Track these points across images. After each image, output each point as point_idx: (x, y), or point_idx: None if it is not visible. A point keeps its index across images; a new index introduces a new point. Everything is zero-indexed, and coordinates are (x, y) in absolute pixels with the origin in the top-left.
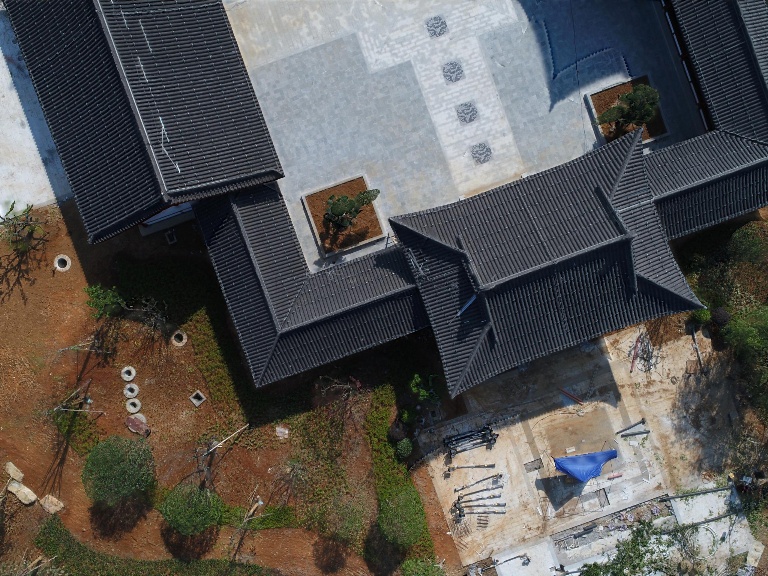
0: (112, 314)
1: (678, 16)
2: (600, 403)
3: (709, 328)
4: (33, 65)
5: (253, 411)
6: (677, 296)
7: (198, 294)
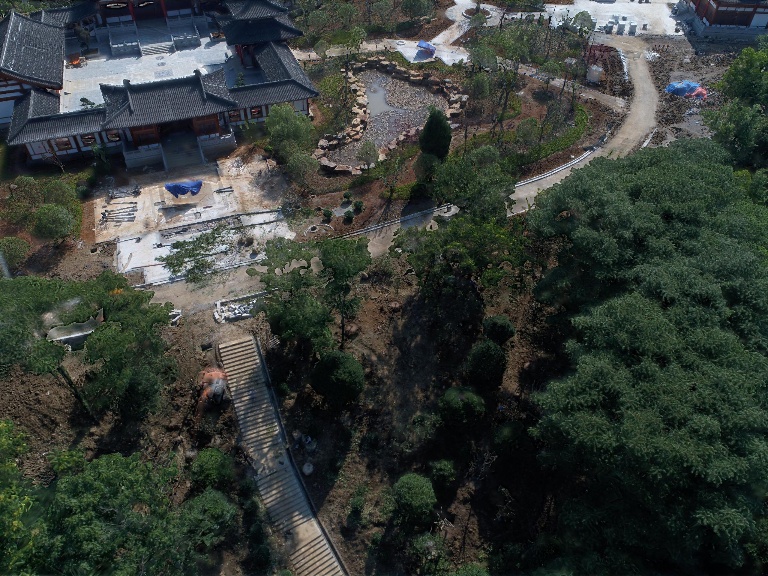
0: None
1: (259, 63)
2: None
3: (276, 158)
4: None
5: (2, 178)
6: (225, 100)
7: None
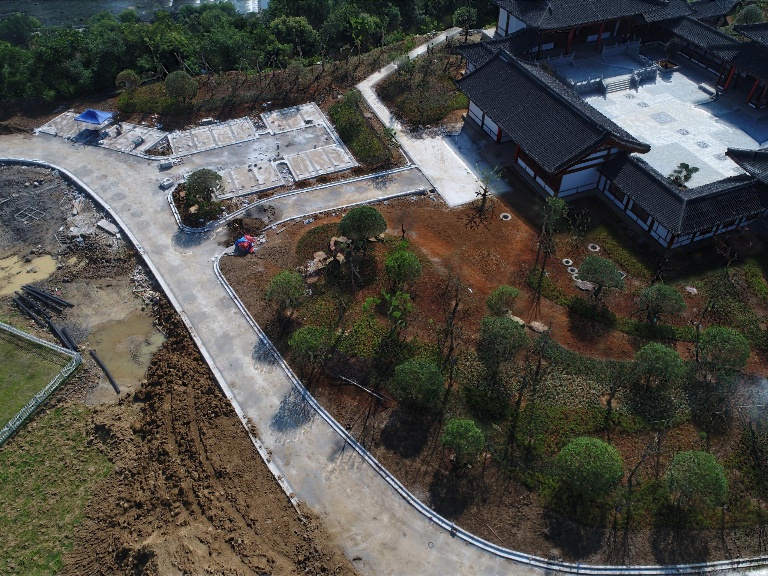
0: None
1: None
2: None
3: None
4: (499, 121)
5: (665, 278)
6: None
7: (599, 226)
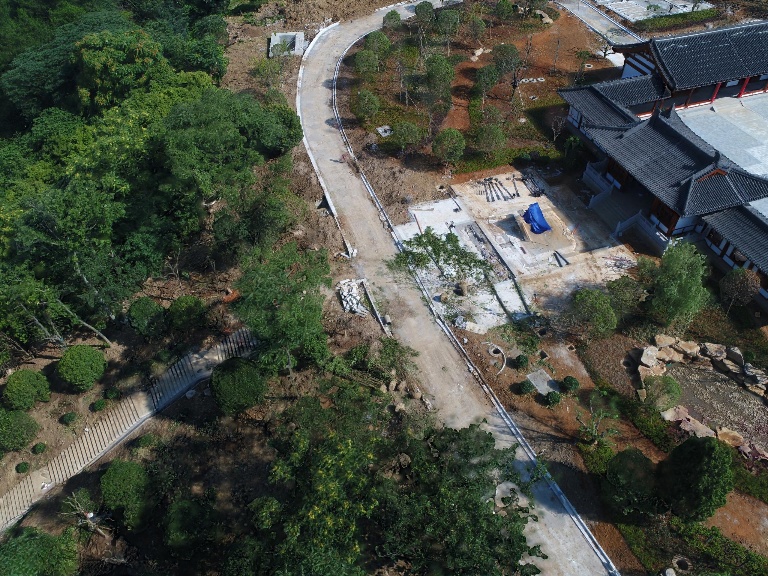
0: (569, 76)
1: None
2: (575, 243)
3: None
4: None
5: (532, 111)
6: None
7: None
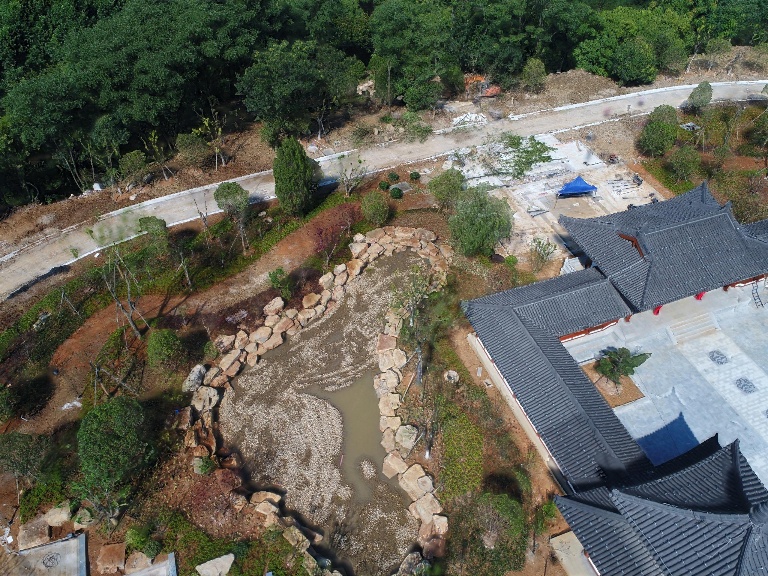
0: None
1: None
2: None
3: None
4: None
5: None
6: None
7: None
